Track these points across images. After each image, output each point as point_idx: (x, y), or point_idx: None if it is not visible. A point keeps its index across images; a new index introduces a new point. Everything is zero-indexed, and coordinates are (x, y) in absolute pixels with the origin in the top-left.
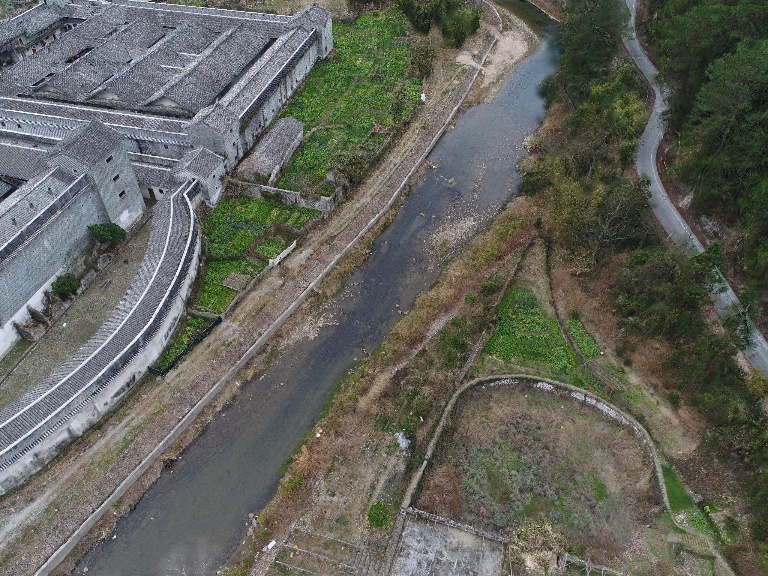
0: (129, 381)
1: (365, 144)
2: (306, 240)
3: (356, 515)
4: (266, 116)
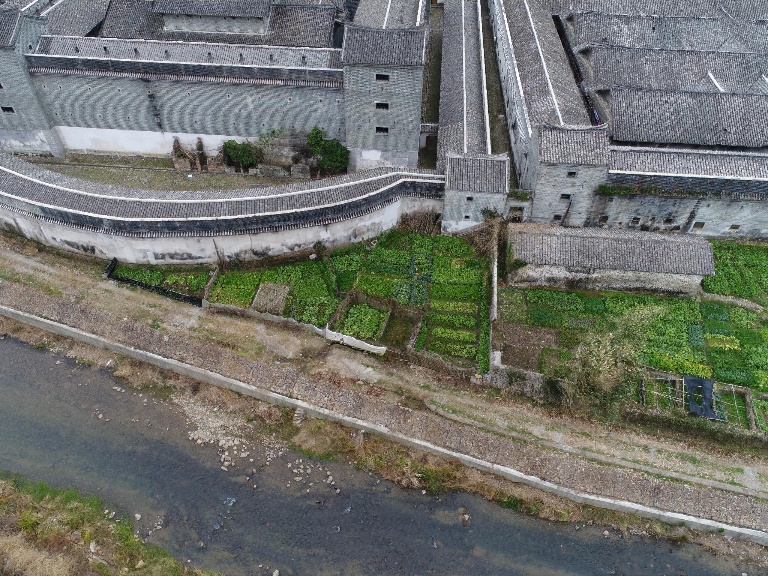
0: (87, 247)
1: (759, 400)
2: (403, 366)
3: None
4: (704, 220)
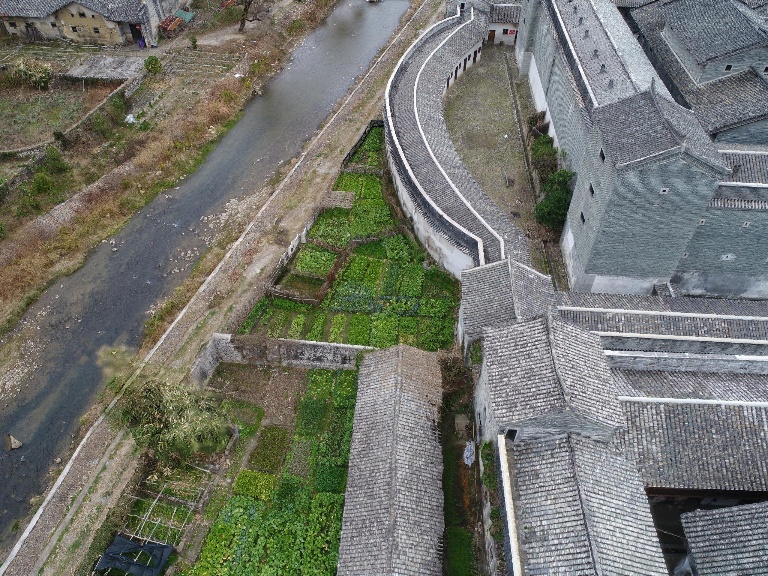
0: None
1: None
2: None
3: (175, 85)
4: None
